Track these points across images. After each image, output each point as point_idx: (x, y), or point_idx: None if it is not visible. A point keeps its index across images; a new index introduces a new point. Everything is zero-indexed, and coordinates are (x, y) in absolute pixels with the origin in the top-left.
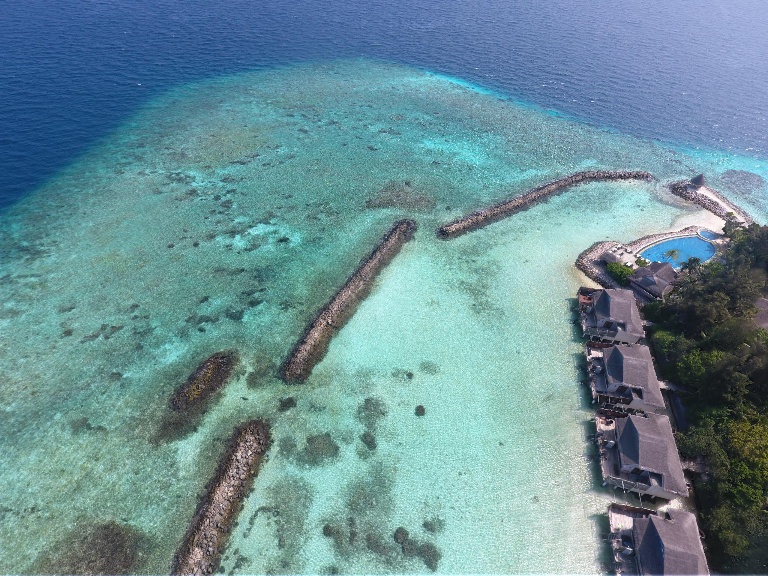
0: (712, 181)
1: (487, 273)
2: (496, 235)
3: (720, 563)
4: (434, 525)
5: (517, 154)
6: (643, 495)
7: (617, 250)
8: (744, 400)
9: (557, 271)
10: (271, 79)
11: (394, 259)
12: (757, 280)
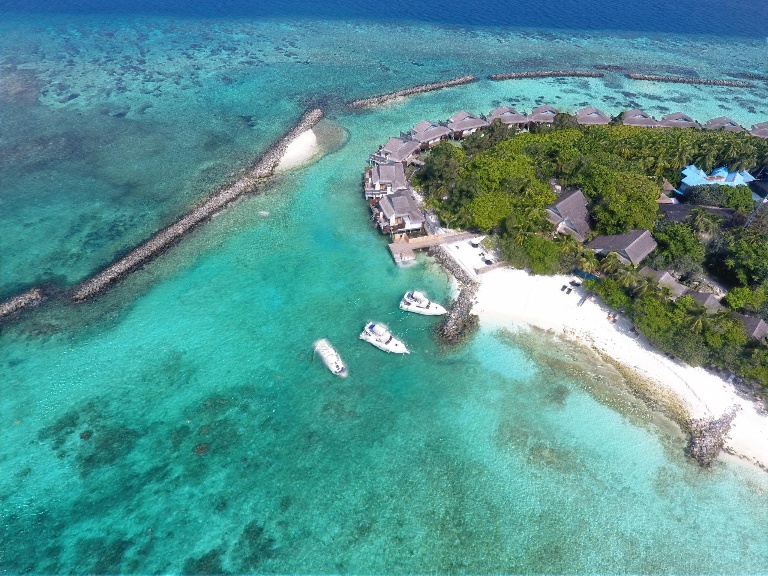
0: None
1: None
2: None
3: None
4: None
5: None
6: None
7: None
8: None
9: None
10: None
11: None
12: None
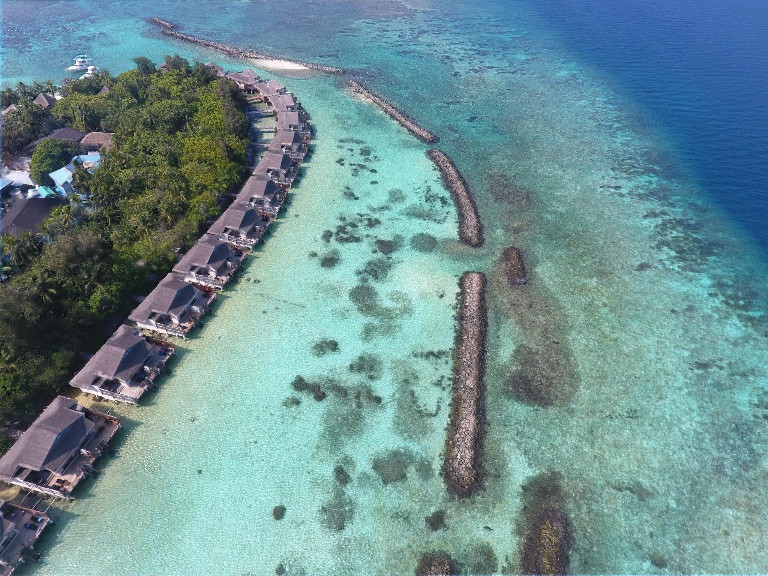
0: None
1: None
2: None
3: (80, 361)
4: (291, 402)
5: None
6: None
7: None
8: None
9: None
10: None
11: None
12: None
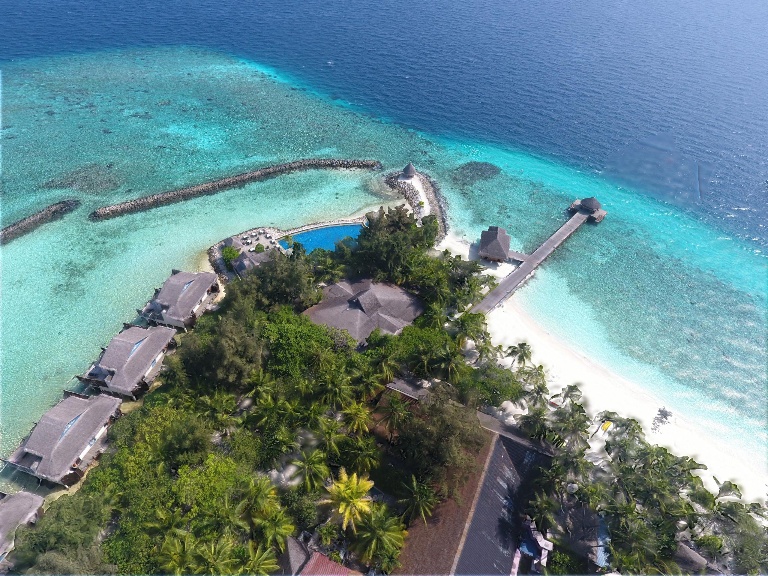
0: (442, 172)
1: (106, 255)
2: (154, 218)
3: None
4: None
5: (257, 141)
6: (43, 479)
7: (257, 235)
8: (180, 384)
9: (183, 255)
10: (67, 63)
11: (18, 238)
12: (354, 267)
